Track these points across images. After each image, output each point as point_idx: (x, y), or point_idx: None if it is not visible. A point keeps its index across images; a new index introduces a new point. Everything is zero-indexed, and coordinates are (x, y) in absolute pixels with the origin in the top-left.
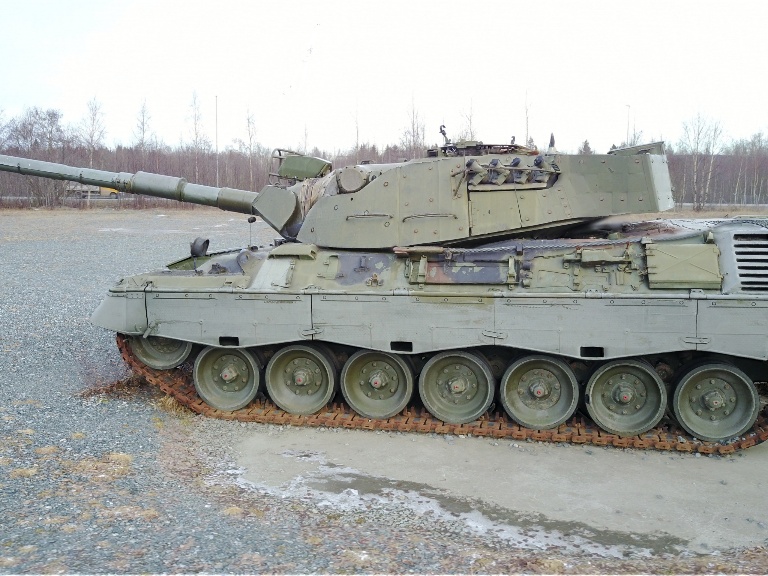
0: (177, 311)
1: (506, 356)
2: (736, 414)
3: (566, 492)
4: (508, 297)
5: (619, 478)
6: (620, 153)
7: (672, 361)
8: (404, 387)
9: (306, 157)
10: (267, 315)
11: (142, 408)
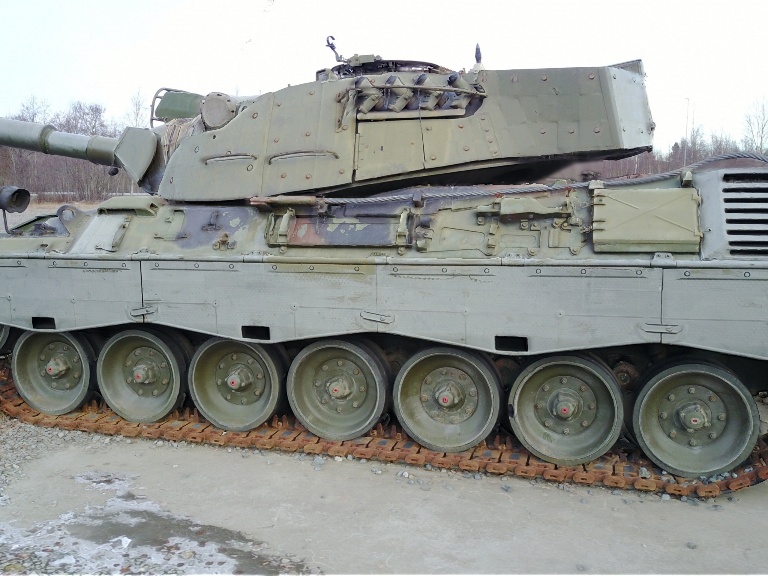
0: None
1: (412, 349)
2: (726, 438)
3: (439, 554)
4: (394, 264)
5: (531, 532)
6: None
7: (639, 360)
8: (269, 389)
9: (189, 94)
10: (87, 288)
11: None
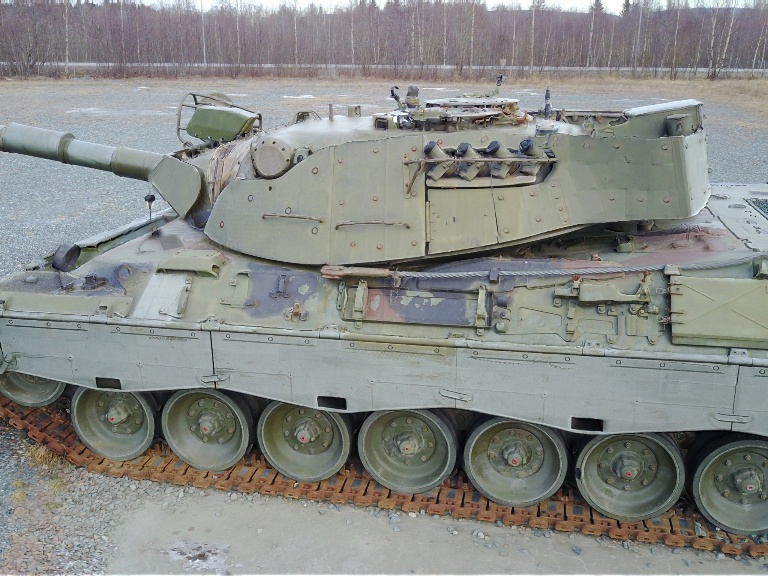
0: (38, 343)
1: None
2: None
3: None
4: (475, 348)
5: None
6: (640, 118)
7: None
8: (339, 444)
9: (221, 111)
10: (154, 354)
11: (4, 462)
